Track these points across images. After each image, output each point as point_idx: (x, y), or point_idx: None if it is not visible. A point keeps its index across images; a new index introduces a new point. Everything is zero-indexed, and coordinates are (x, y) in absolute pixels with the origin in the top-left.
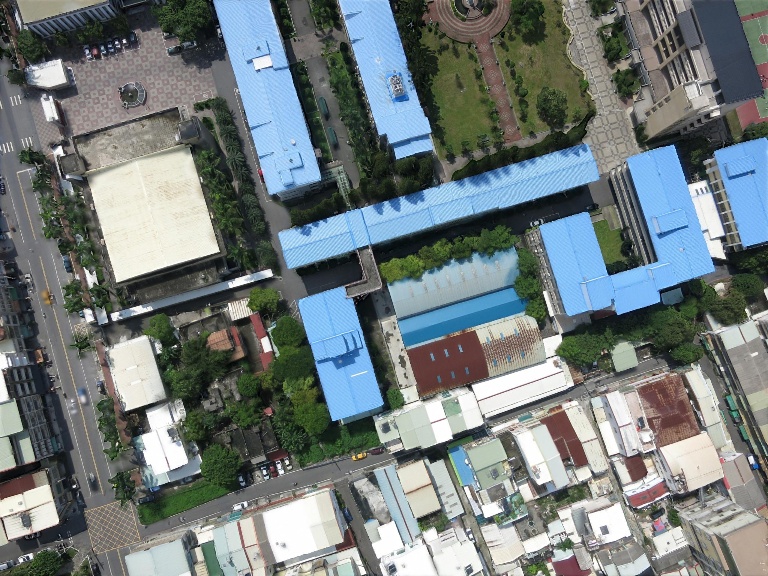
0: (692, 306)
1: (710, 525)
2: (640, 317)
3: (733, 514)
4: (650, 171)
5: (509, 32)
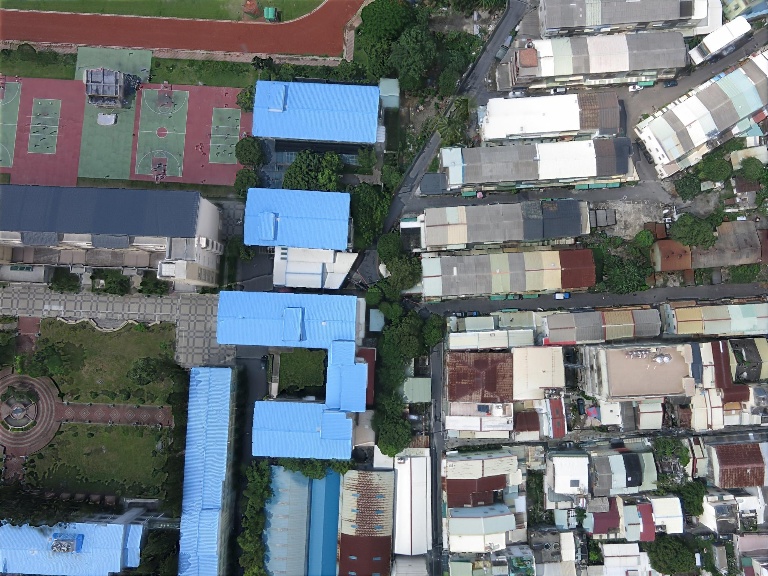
0: (390, 308)
1: (599, 392)
2: (383, 365)
3: (596, 365)
4: (237, 326)
5: (63, 382)
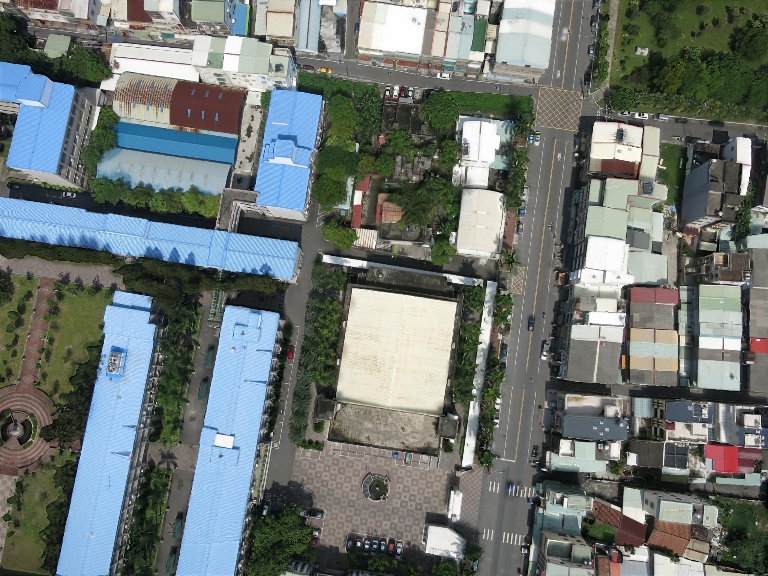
0: None
1: None
2: None
3: None
4: None
5: None
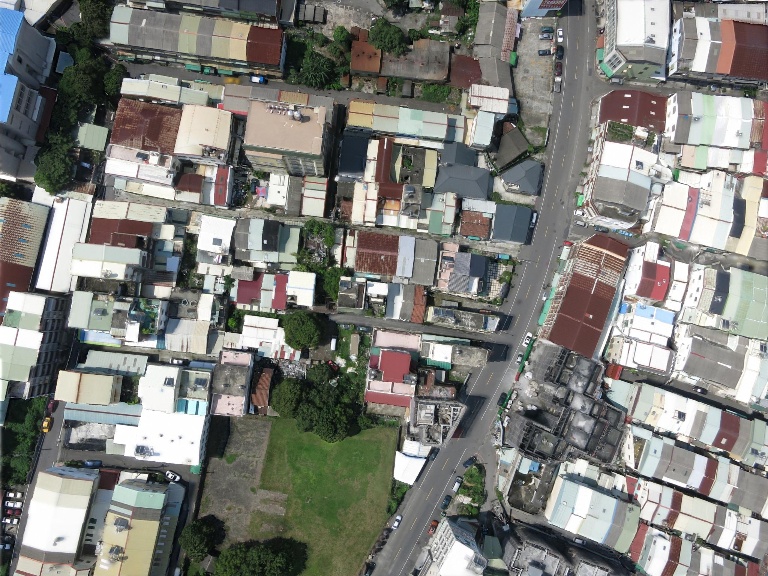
0: (78, 51)
1: None
2: None
3: None
4: None
5: None
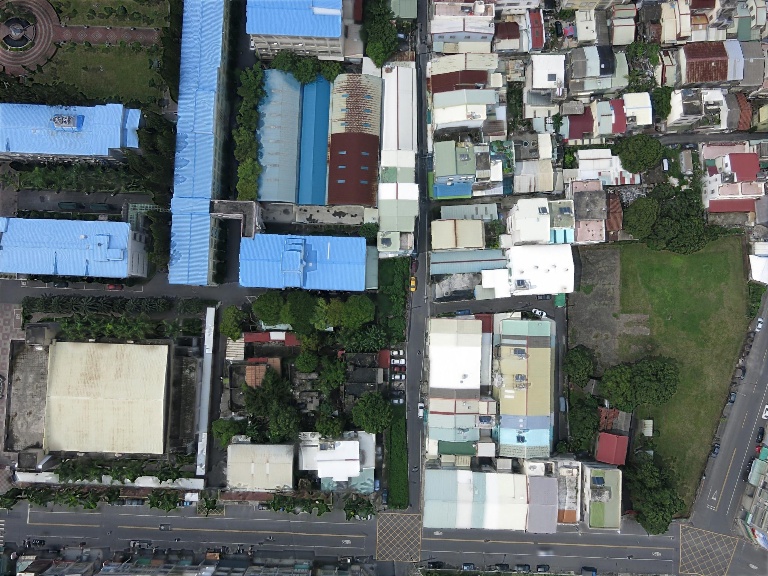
0: None
1: None
2: None
3: None
4: None
5: (60, 6)
